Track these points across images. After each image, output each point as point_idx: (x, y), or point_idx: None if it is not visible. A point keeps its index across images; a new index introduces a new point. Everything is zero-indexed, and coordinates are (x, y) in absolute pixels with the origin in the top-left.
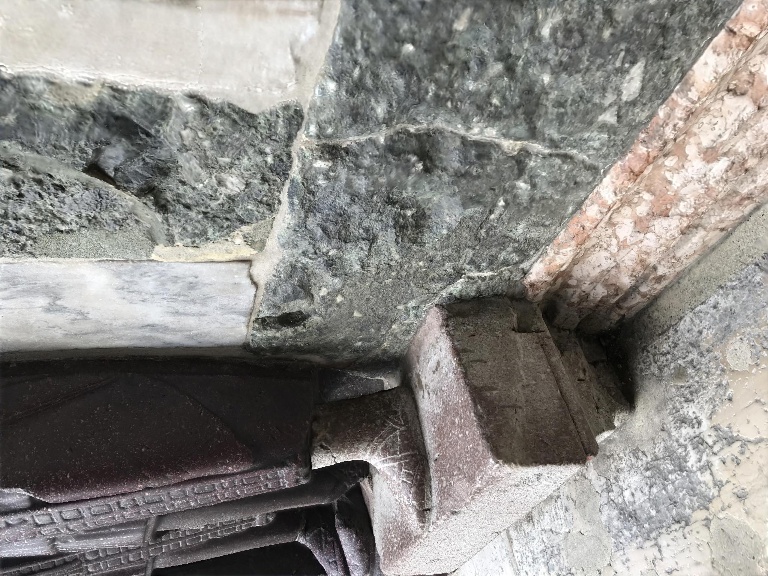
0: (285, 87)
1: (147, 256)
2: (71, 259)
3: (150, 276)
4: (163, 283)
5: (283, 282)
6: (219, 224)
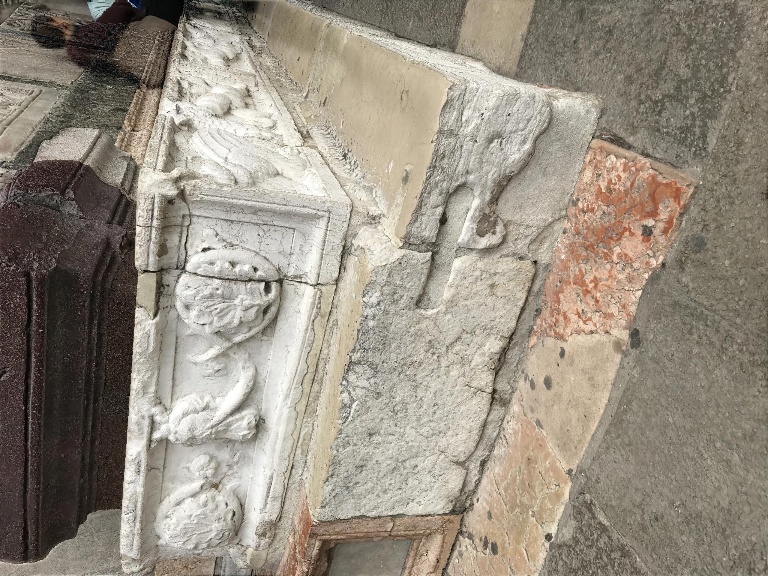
0: (2, 160)
1: None
2: None
3: None
4: None
5: None
6: None
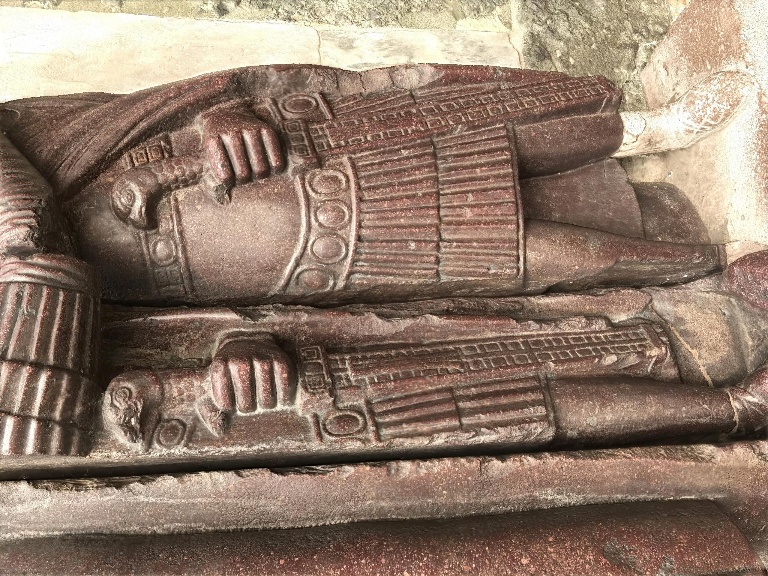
0: None
1: (454, 28)
2: (418, 30)
3: (458, 41)
4: (465, 46)
5: (531, 46)
6: (484, 3)
